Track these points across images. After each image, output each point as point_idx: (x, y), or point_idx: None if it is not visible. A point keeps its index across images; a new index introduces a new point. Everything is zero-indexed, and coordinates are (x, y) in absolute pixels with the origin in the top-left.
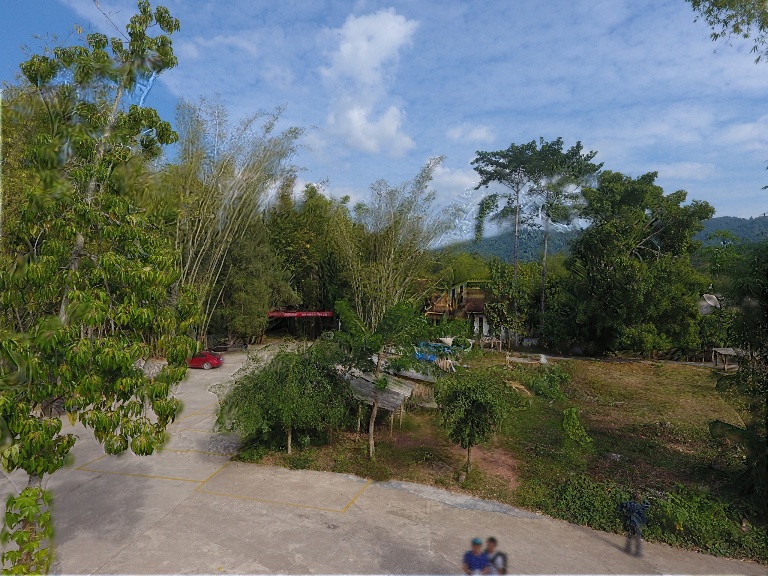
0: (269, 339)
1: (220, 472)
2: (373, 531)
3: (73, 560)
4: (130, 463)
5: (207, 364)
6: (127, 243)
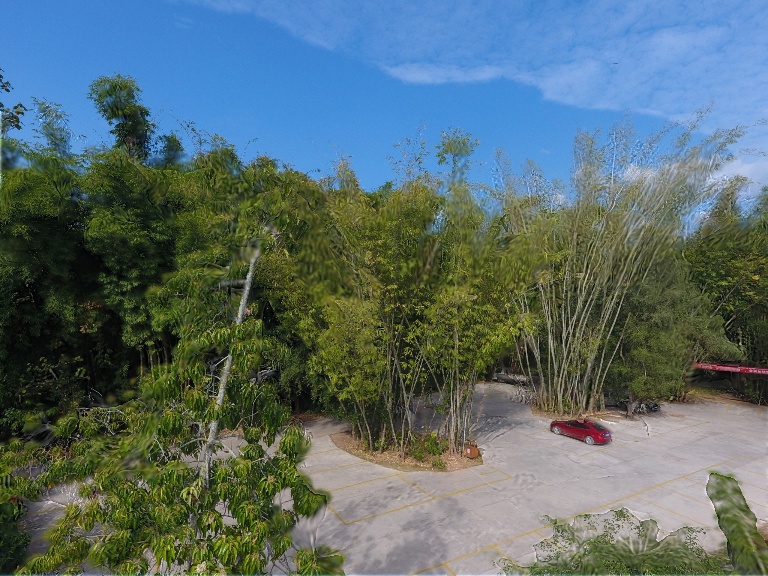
0: (700, 394)
1: None
2: None
3: None
4: None
5: (590, 438)
6: (183, 528)
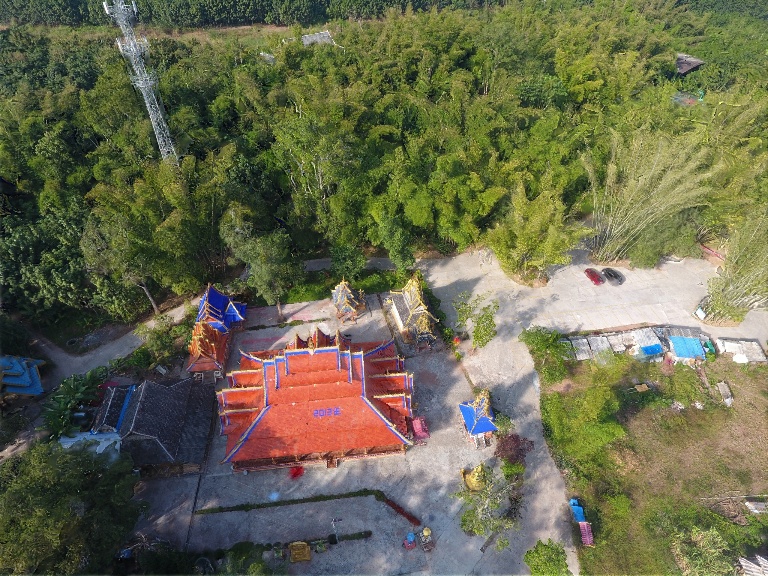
0: None
1: None
2: (516, 373)
3: None
4: None
5: (594, 282)
6: None
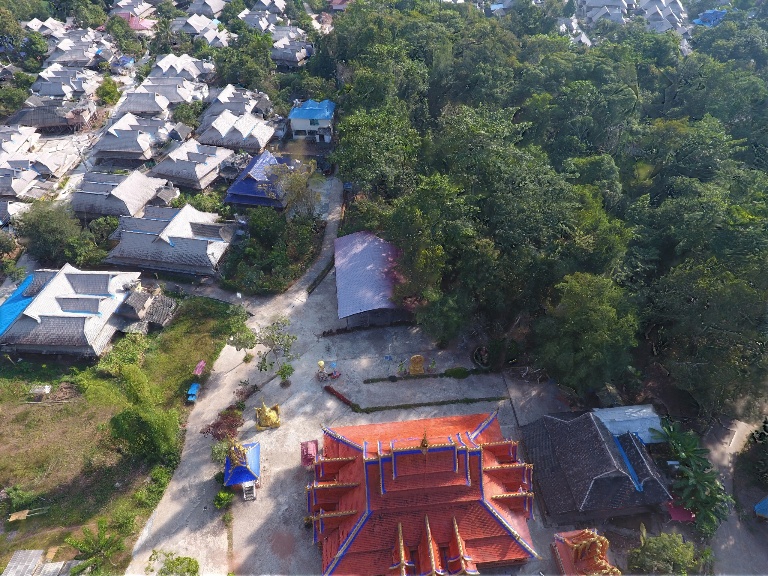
0: None
1: None
2: None
3: None
4: None
5: None
6: None
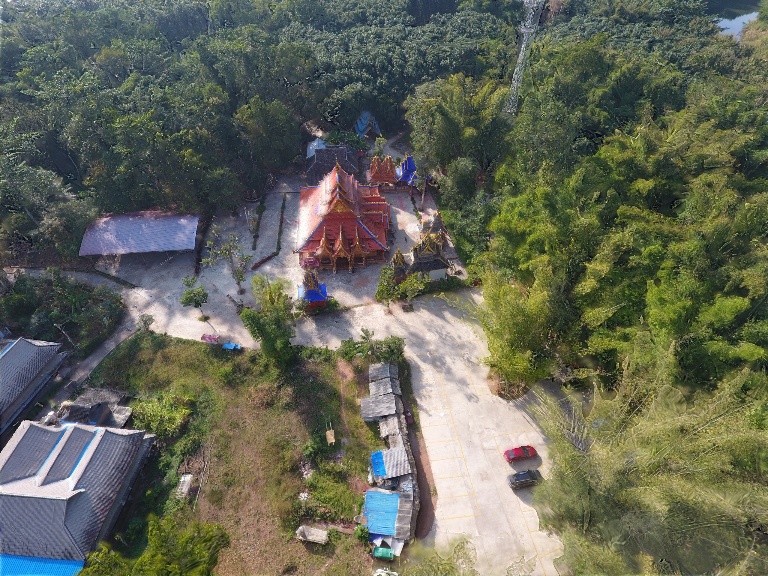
0: None
1: None
2: None
3: None
4: None
5: None
6: None
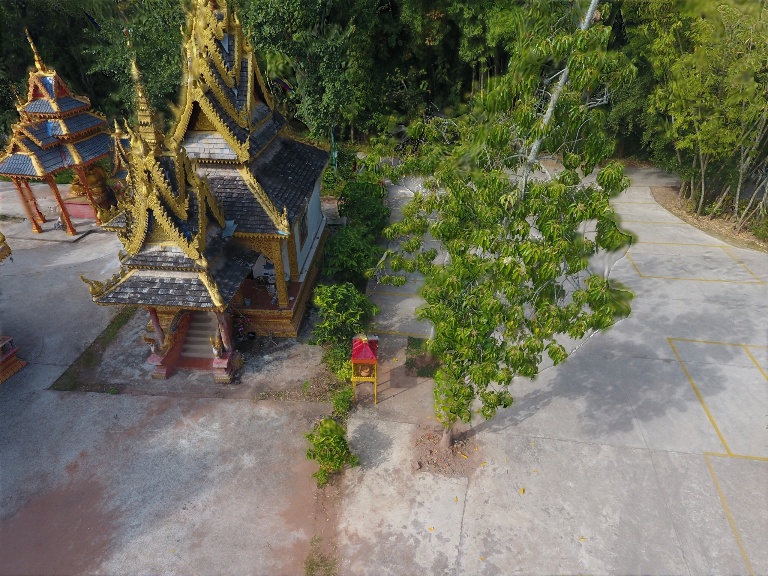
0: None
1: (767, 463)
2: None
3: (545, 415)
4: (712, 368)
5: None
6: None
